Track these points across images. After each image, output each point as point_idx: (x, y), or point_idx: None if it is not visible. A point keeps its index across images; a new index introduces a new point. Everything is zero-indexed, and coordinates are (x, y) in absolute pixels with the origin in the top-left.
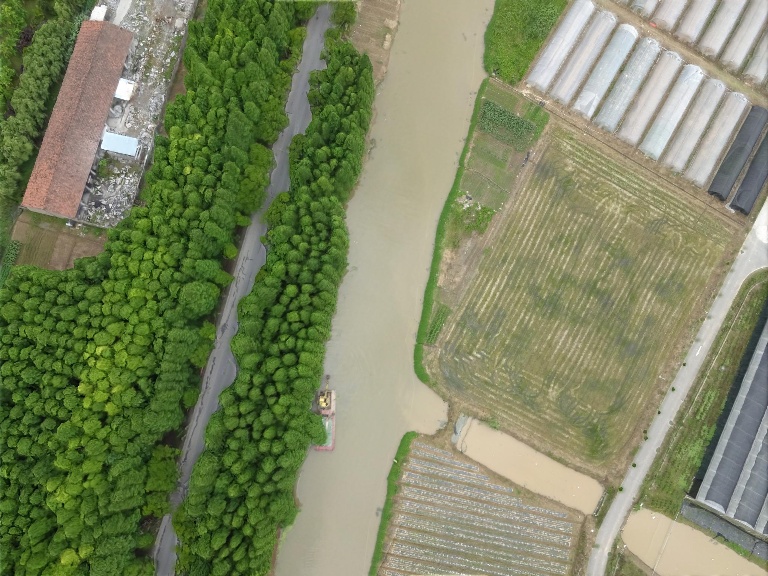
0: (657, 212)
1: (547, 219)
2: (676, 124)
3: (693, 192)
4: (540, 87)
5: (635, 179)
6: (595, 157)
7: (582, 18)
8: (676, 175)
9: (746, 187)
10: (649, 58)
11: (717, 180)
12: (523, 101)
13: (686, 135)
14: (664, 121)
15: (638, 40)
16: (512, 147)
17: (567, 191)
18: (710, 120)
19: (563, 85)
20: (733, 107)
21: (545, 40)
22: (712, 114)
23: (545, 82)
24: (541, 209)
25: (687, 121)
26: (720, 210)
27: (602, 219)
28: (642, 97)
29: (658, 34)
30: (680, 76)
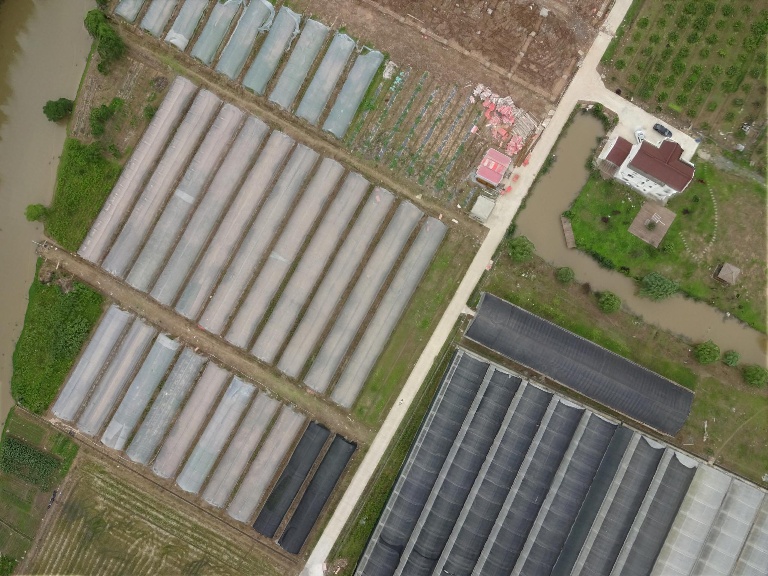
0: (196, 552)
1: (74, 566)
2: (220, 449)
3: (239, 527)
4: (68, 415)
5: (173, 515)
6: (129, 492)
7: (112, 333)
8: (219, 508)
9: (294, 523)
10: (194, 370)
11: (261, 516)
12: (50, 432)
13: (234, 459)
14: (200, 451)
15: (183, 348)
16: (37, 487)
17: (96, 533)
18: (262, 440)
19: (96, 410)
20: (291, 422)
21: (76, 358)
22: (265, 432)
23: (73, 409)
24: (68, 555)
25: (235, 443)
26: (270, 546)
27: (134, 563)
28: (182, 419)
29: (206, 339)
30: (226, 391)
